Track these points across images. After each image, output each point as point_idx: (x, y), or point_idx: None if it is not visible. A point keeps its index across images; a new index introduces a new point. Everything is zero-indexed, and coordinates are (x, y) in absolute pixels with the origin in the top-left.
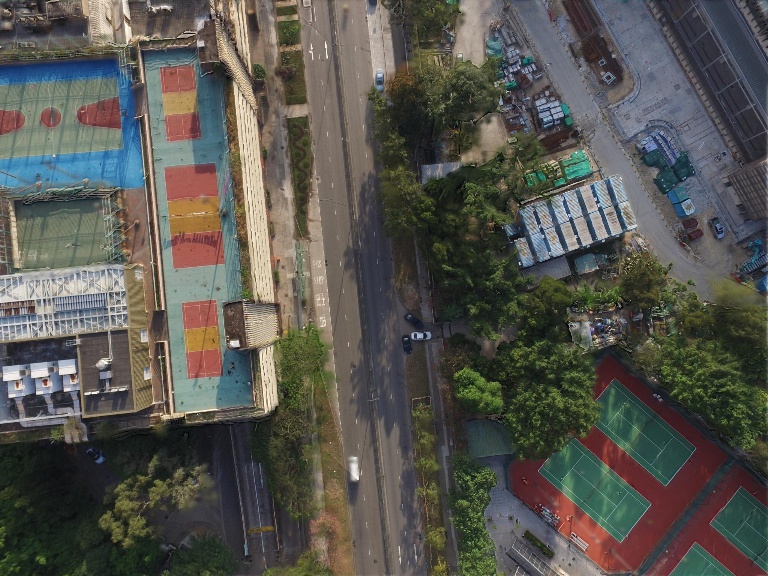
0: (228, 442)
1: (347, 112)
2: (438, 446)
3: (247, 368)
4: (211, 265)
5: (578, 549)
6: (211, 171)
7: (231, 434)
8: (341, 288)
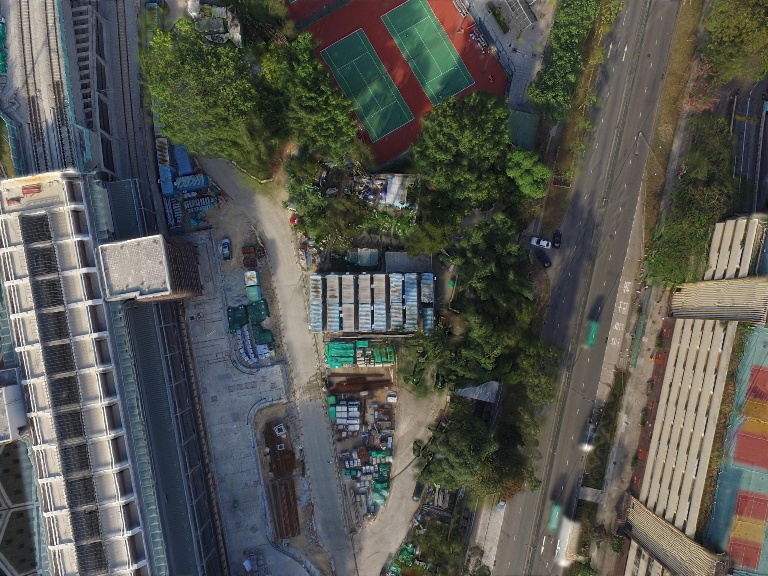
0: (759, 206)
1: (542, 478)
2: (559, 137)
3: (762, 265)
4: (765, 371)
5: (462, 1)
6: (738, 459)
7: (755, 213)
8: (601, 312)
